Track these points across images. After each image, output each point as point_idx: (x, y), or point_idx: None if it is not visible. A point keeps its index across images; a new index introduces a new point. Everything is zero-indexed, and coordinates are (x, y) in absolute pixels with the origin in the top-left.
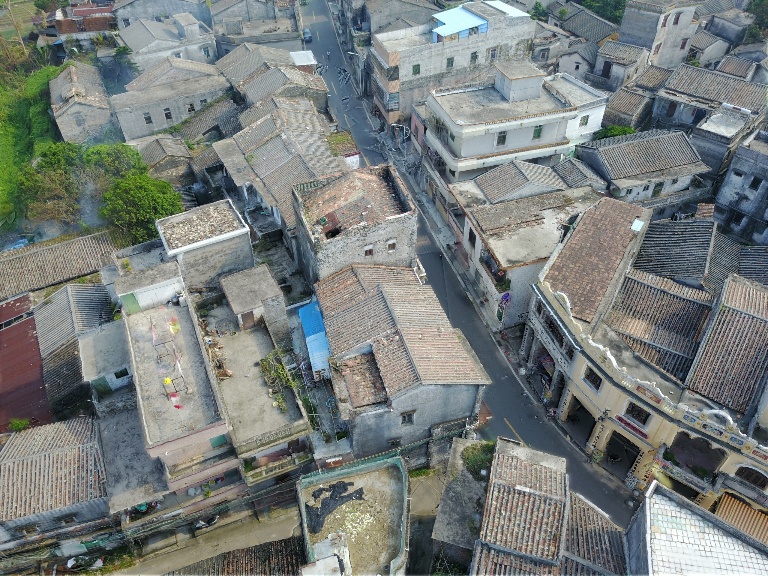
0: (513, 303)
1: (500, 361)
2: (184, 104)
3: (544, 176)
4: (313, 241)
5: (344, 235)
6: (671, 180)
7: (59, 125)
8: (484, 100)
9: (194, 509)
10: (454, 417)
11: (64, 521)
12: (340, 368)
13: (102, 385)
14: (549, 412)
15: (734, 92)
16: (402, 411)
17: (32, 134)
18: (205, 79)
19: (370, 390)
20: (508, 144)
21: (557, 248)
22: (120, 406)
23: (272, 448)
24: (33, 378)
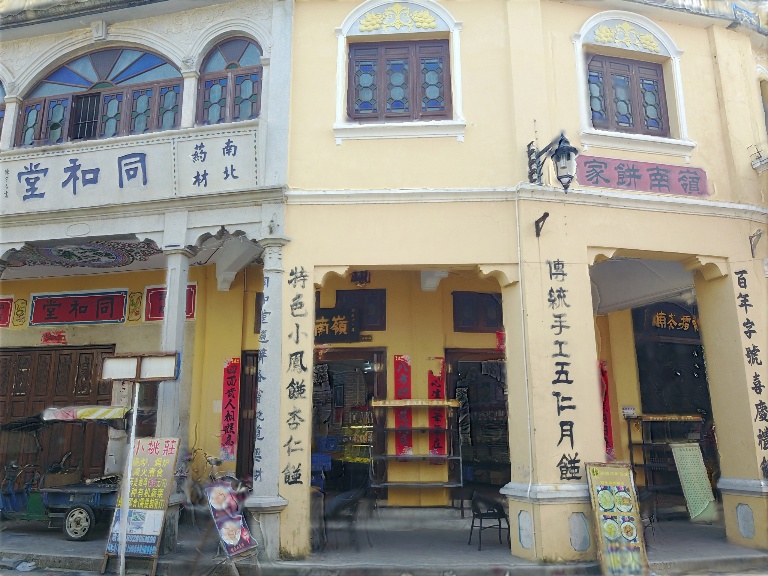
0: None
1: None
2: None
3: None
4: None
5: None
6: None
7: None
8: None
9: None
10: None
11: None
12: None
13: None
14: (225, 524)
15: None
16: None
17: None
18: None
19: None
20: None
21: None
22: None
23: None
24: None
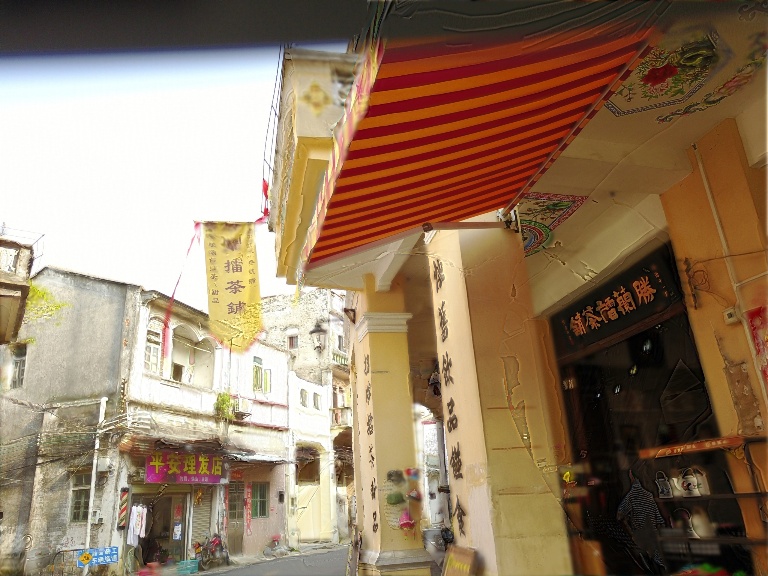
0: None
1: None
2: None
3: None
4: None
5: None
6: None
7: None
8: None
9: None
10: (88, 390)
11: None
12: None
13: None
14: None
15: None
16: None
17: None
18: None
19: None
20: None
21: None
22: None
23: None
24: None
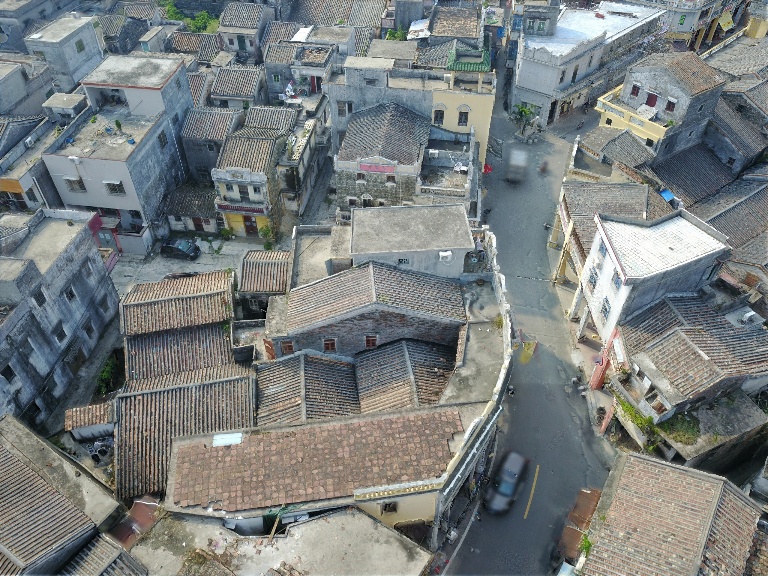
0: None
1: (456, 571)
2: None
3: None
4: None
5: None
6: None
7: None
8: None
9: None
10: None
11: None
12: None
13: None
14: None
15: None
16: None
17: None
18: None
19: (767, 551)
20: None
21: (368, 491)
22: None
23: None
24: None
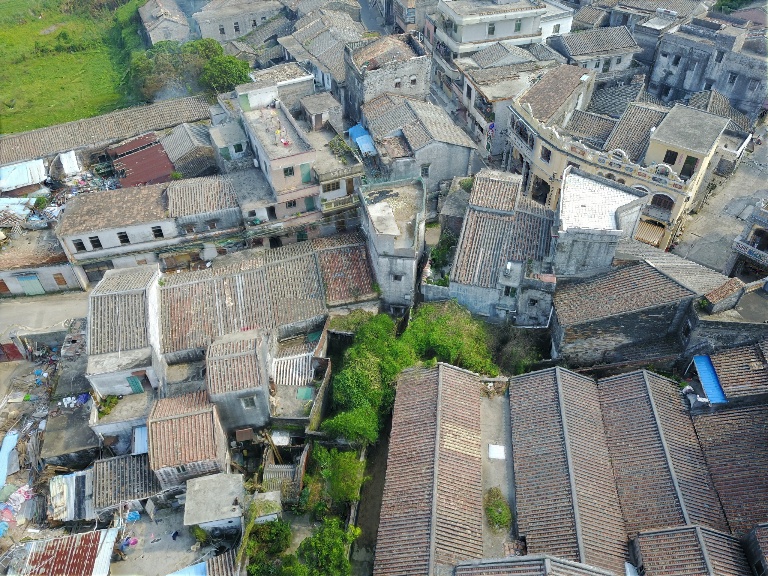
0: (498, 134)
1: None
2: (249, 20)
3: (522, 53)
4: (361, 73)
5: (382, 68)
6: (616, 60)
7: (152, 37)
8: (479, 4)
9: (289, 225)
10: None
11: (210, 227)
12: (382, 141)
13: (227, 156)
14: None
15: (670, 5)
16: (422, 163)
17: (128, 47)
18: (264, 3)
19: (401, 151)
20: (497, 34)
21: (527, 86)
22: (240, 166)
23: (337, 194)
24: (169, 172)
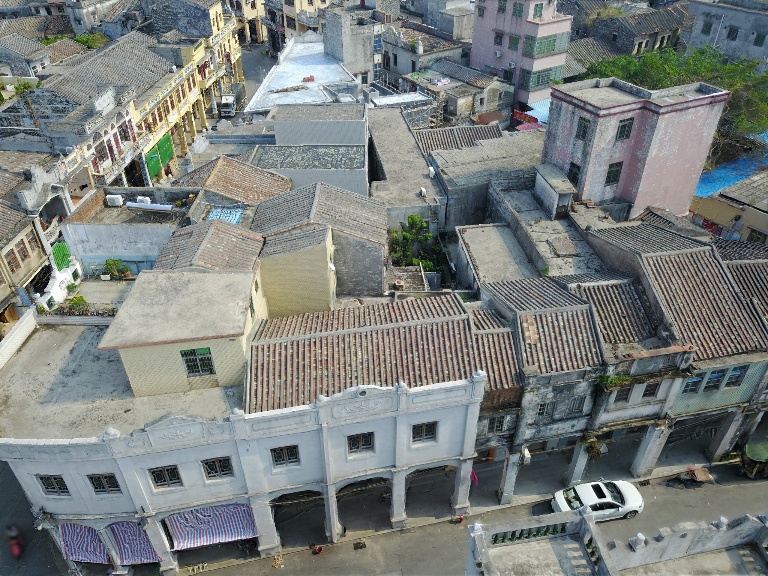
0: None
1: None
2: None
3: None
4: None
5: None
6: None
7: None
8: None
9: None
10: None
11: (15, 17)
12: None
13: None
14: None
15: None
16: None
17: None
18: None
19: None
20: None
21: None
22: None
23: None
24: None
